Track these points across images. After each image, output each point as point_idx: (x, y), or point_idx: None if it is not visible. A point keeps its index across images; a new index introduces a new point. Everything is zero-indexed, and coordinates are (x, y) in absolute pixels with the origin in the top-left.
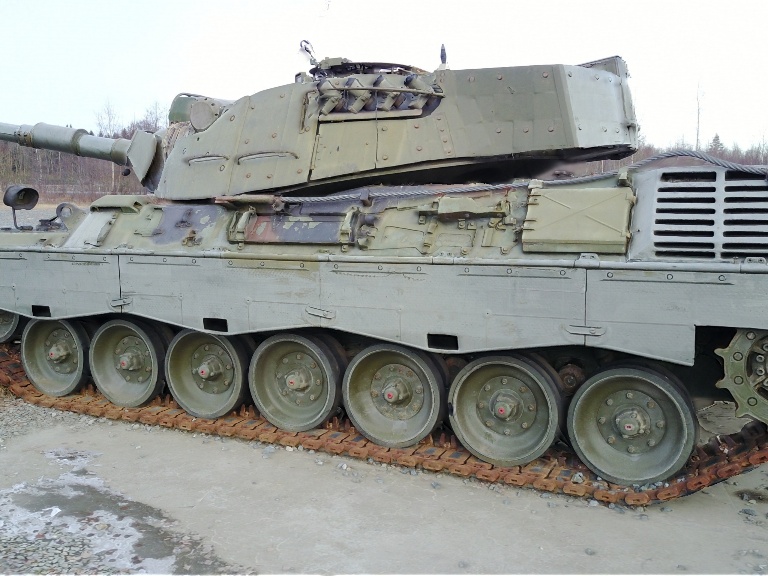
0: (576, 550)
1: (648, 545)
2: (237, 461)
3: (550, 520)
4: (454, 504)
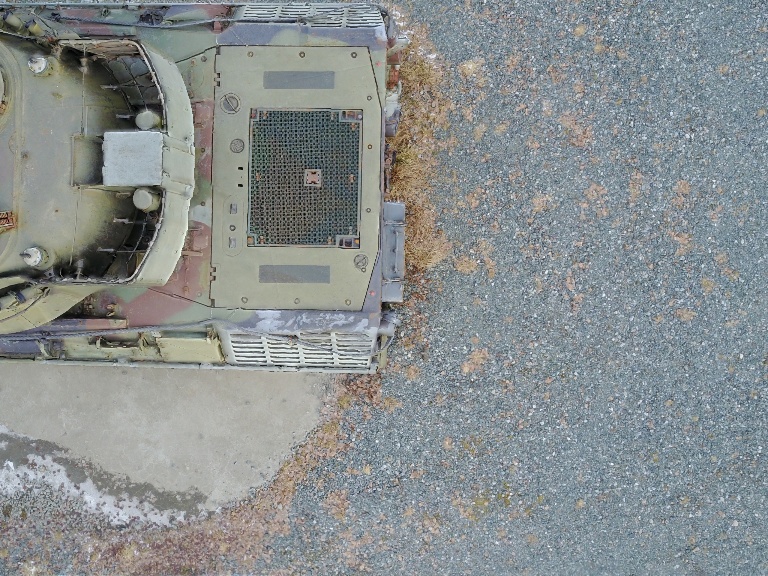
0: (242, 403)
1: (270, 385)
2: (52, 374)
3: (226, 378)
4: (180, 380)
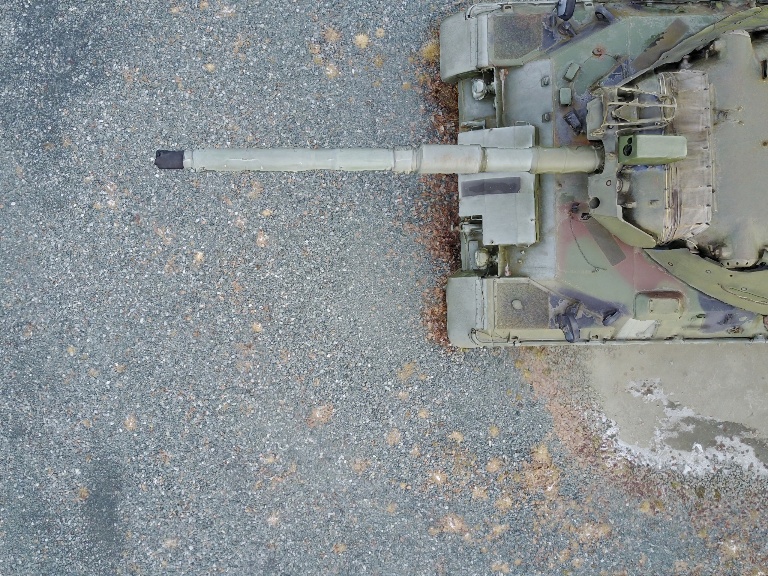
0: None
1: None
2: (737, 357)
3: None
4: None
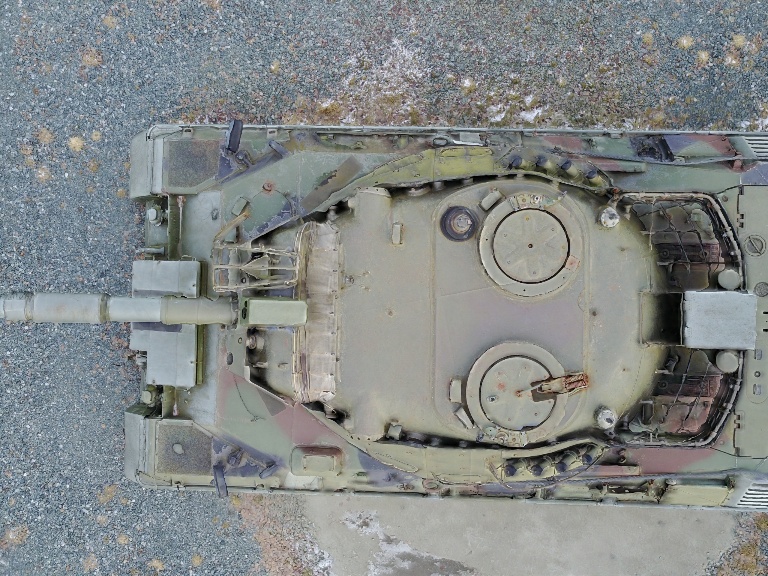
0: (654, 522)
1: None
2: None
3: None
4: None
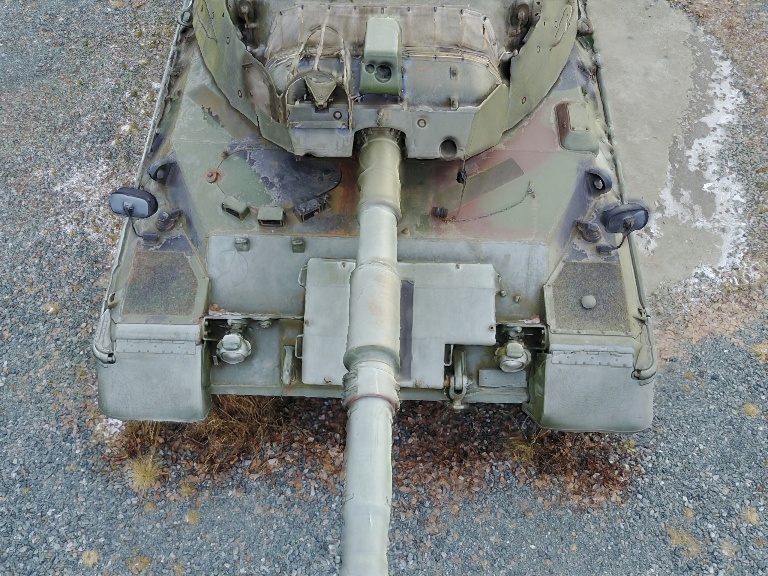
0: None
1: None
2: None
3: None
4: None
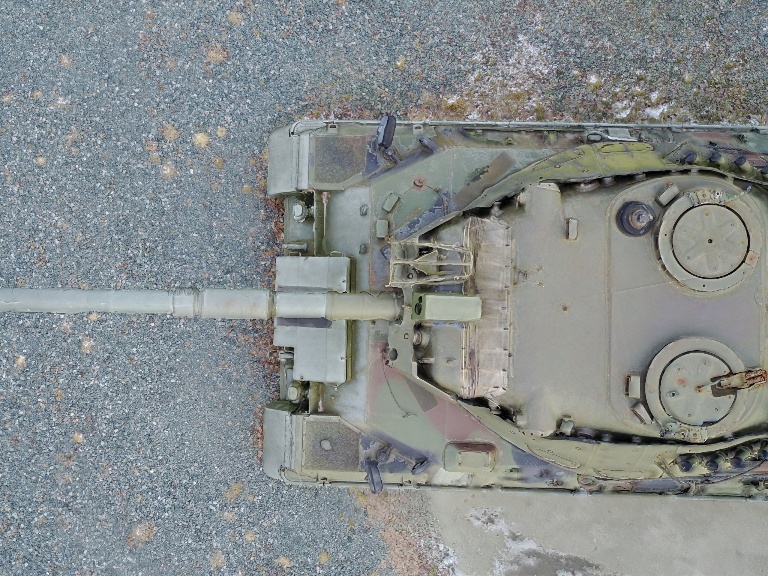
0: None
1: None
2: None
3: None
4: None
